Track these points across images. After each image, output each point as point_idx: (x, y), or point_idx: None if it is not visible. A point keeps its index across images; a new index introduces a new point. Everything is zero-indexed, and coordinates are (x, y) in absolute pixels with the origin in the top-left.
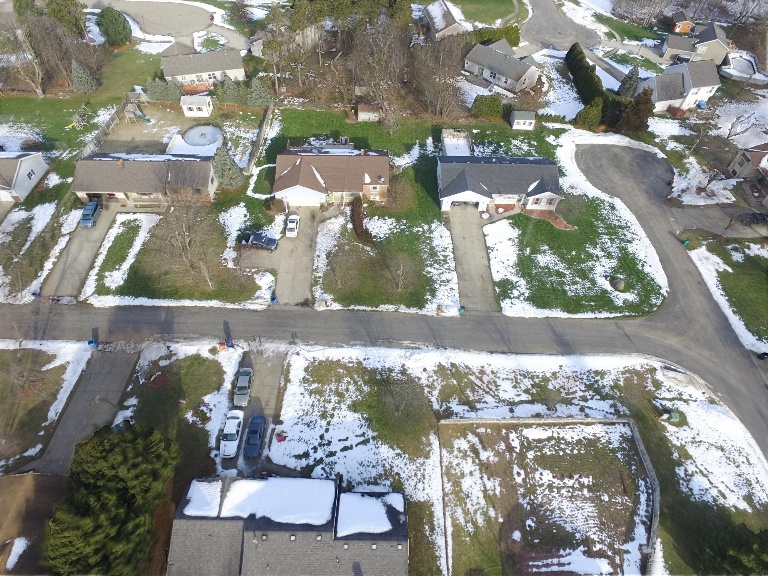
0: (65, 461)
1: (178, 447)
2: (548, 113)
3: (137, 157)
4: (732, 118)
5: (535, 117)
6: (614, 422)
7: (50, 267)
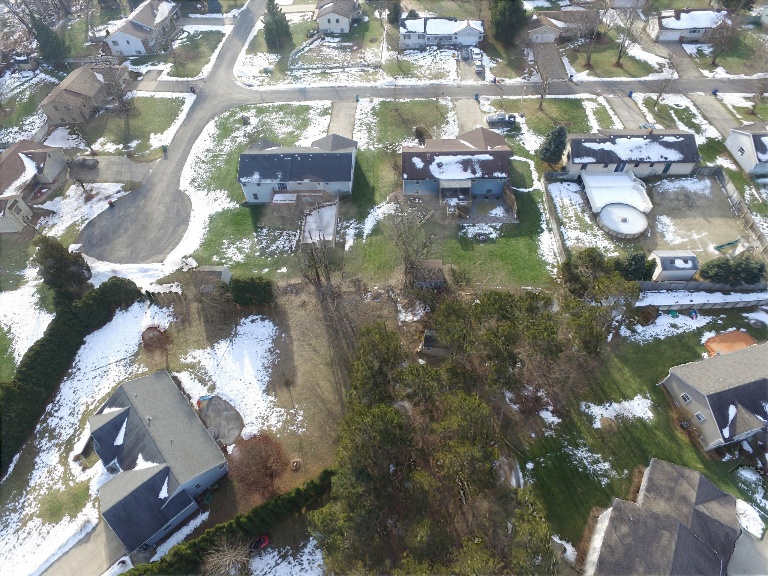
0: (545, 48)
1: None
2: (155, 322)
3: (647, 147)
4: None
5: None
6: (296, 68)
7: (641, 108)
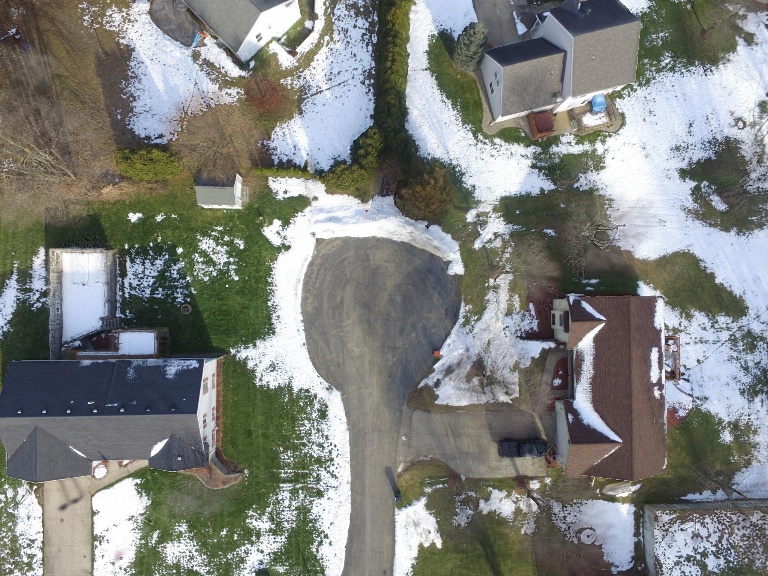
0: None
1: None
2: (291, 140)
3: None
4: (644, 130)
5: (257, 163)
6: None
7: None
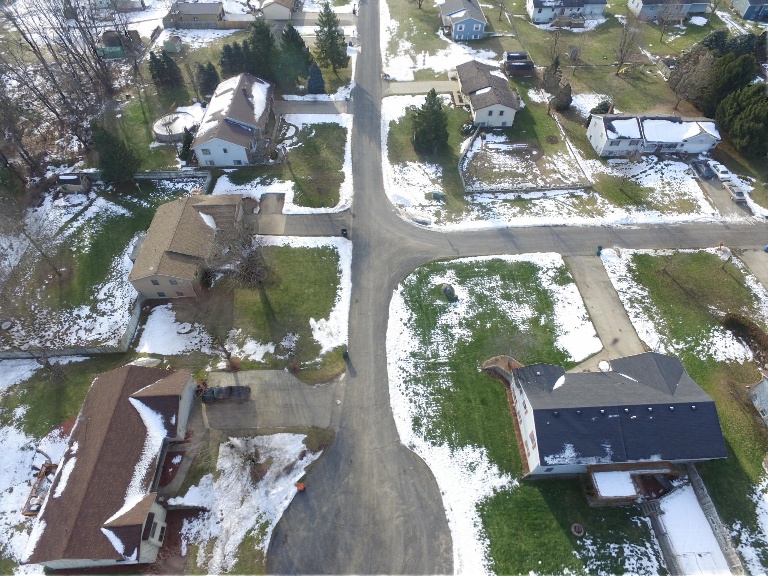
0: None
1: (743, 145)
2: None
3: None
4: None
5: None
6: (476, 191)
7: None
